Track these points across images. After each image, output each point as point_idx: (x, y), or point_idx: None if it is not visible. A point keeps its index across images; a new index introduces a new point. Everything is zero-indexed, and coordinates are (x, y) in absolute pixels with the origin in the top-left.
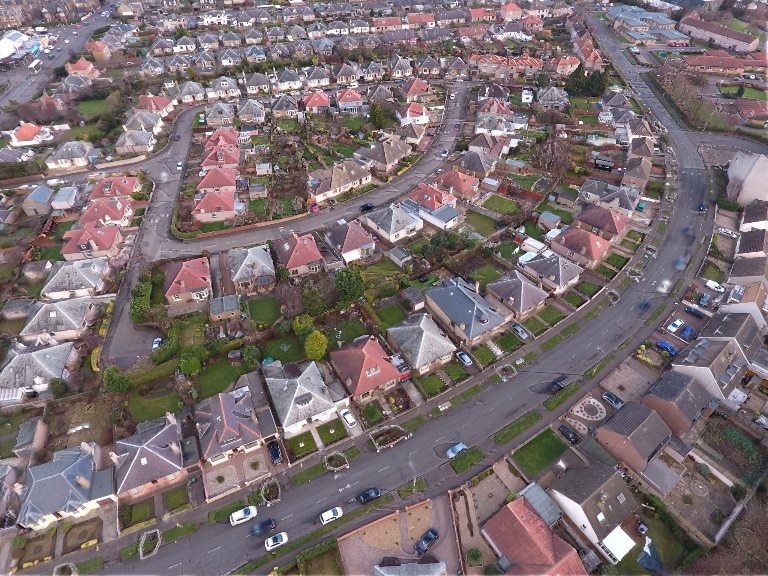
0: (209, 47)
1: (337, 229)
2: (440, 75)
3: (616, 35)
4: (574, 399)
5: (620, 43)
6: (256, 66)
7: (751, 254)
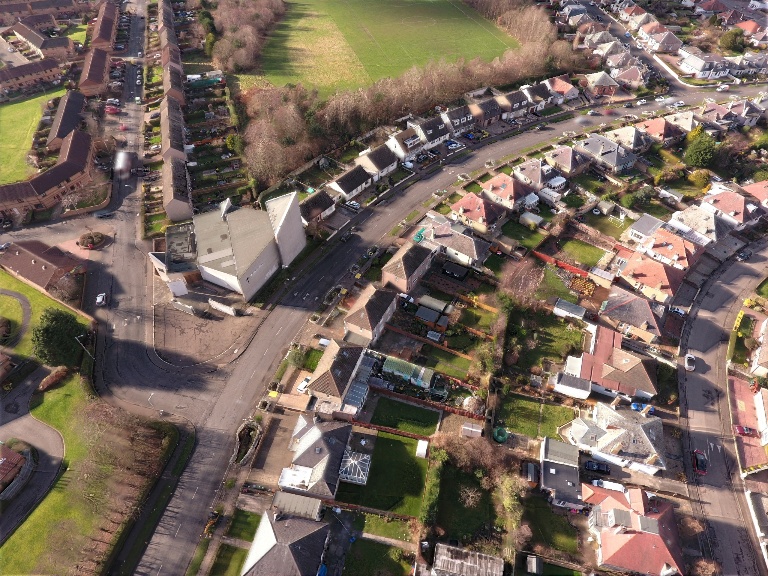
0: None
1: None
2: None
3: None
4: (531, 124)
5: None
6: None
7: None
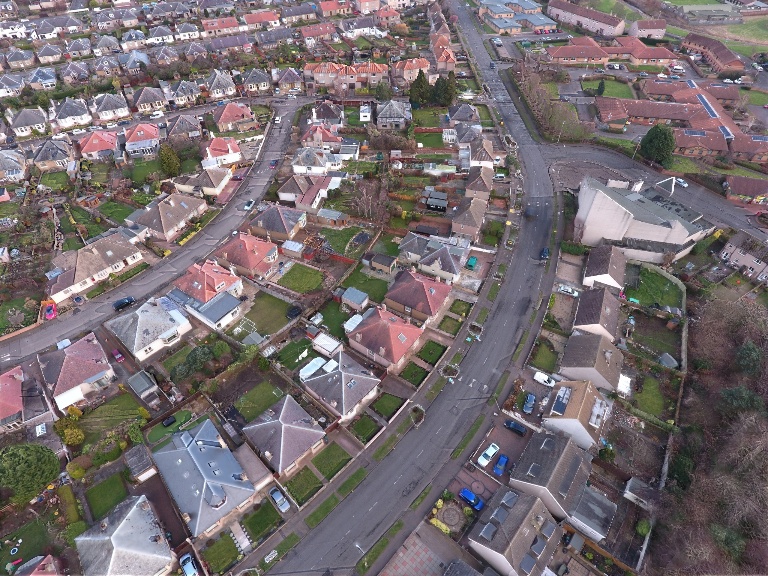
0: None
1: (53, 357)
2: (268, 91)
3: (480, 24)
4: None
5: (483, 34)
6: None
7: (588, 326)
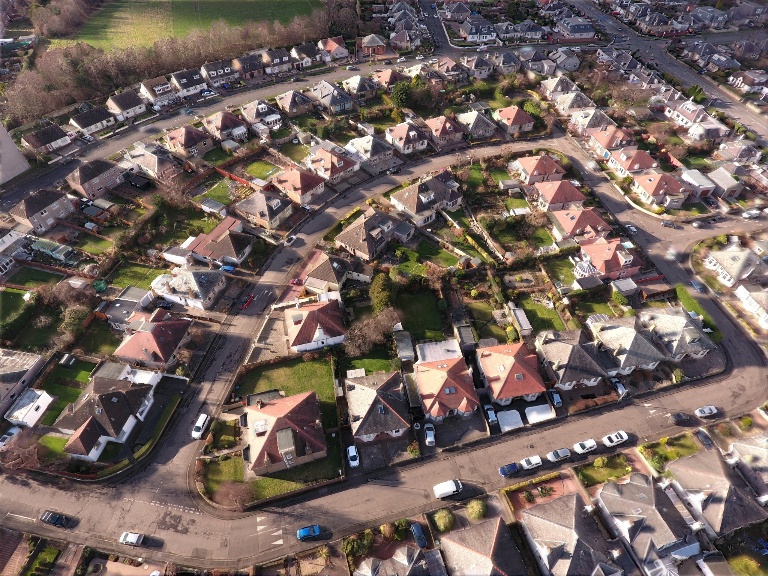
0: None
1: None
2: (178, 569)
3: None
4: (290, 77)
5: None
6: None
7: None
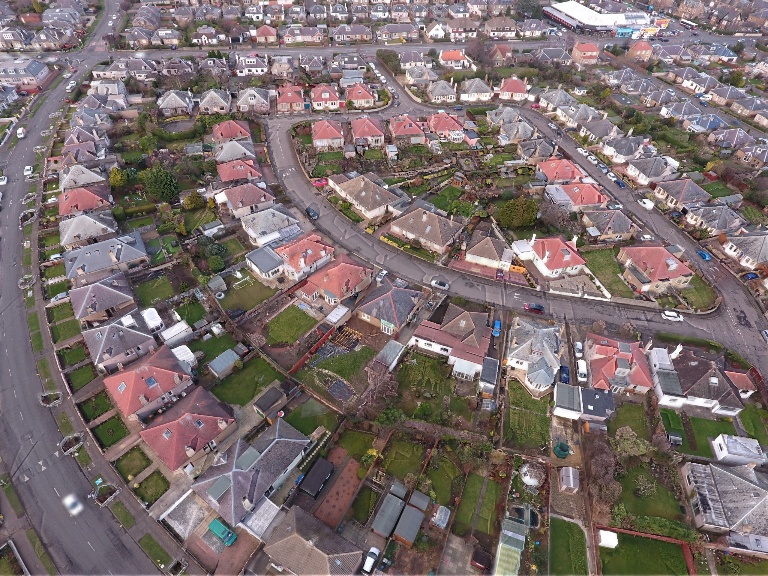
0: (715, 99)
1: None
2: None
3: None
4: None
5: None
6: (655, 126)
7: None
